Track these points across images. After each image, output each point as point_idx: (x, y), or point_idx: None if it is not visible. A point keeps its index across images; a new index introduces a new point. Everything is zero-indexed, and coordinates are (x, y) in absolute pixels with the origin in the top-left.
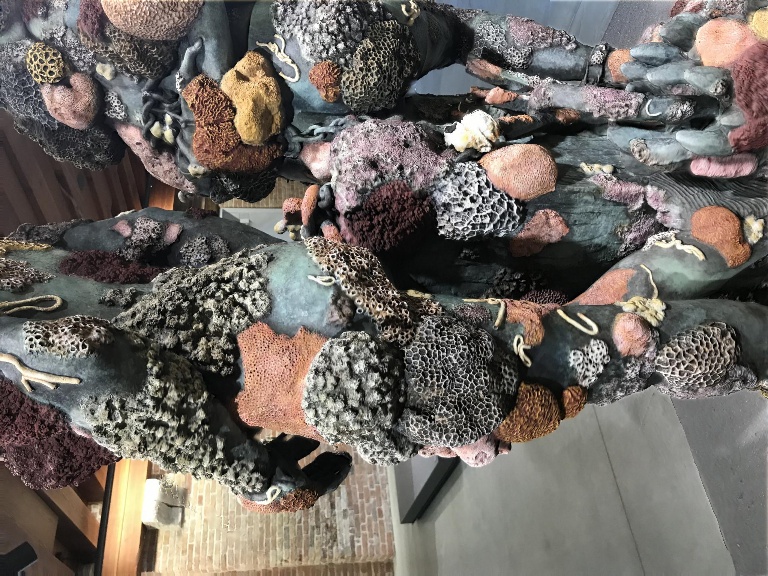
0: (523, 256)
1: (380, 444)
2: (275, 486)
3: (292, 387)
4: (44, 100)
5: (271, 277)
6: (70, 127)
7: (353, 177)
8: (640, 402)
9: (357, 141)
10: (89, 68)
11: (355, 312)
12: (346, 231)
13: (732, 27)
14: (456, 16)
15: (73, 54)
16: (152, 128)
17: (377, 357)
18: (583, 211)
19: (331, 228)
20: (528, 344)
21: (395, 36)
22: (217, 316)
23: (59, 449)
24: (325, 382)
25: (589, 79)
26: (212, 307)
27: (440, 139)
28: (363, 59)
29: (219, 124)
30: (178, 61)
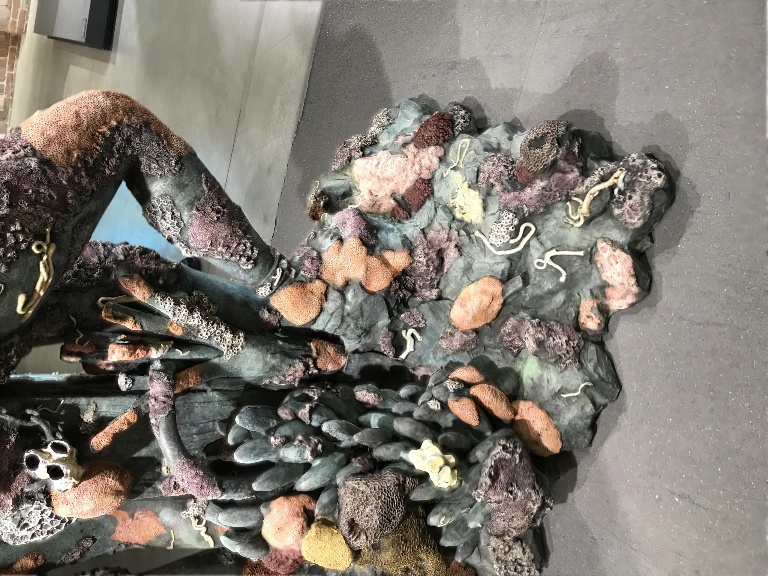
0: None
1: None
2: None
3: None
4: None
5: None
6: None
7: None
8: None
9: None
10: None
11: None
12: None
13: (290, 533)
14: (137, 158)
15: None
16: None
17: None
18: None
19: None
20: None
21: None
22: None
23: None
24: None
25: None
26: None
27: (20, 455)
28: None
29: None
30: None
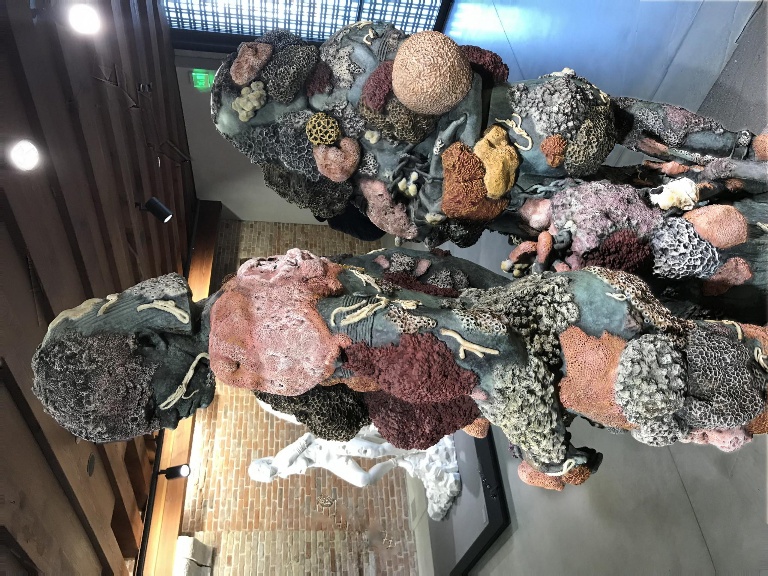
0: (712, 295)
1: (667, 424)
2: (571, 459)
3: (605, 375)
4: (314, 157)
5: (575, 293)
6: (327, 180)
7: (593, 225)
8: (728, 454)
9: (587, 198)
10: (357, 134)
11: (643, 321)
12: (577, 268)
13: None
14: (616, 104)
15: (347, 122)
16: (400, 183)
17: (677, 353)
18: (764, 260)
19: (564, 266)
20: (765, 354)
21: (605, 118)
22: (548, 319)
23: (435, 414)
24: (641, 369)
25: (734, 158)
26: (544, 312)
27: (646, 199)
28: (587, 135)
29: (472, 181)
30: (436, 131)
